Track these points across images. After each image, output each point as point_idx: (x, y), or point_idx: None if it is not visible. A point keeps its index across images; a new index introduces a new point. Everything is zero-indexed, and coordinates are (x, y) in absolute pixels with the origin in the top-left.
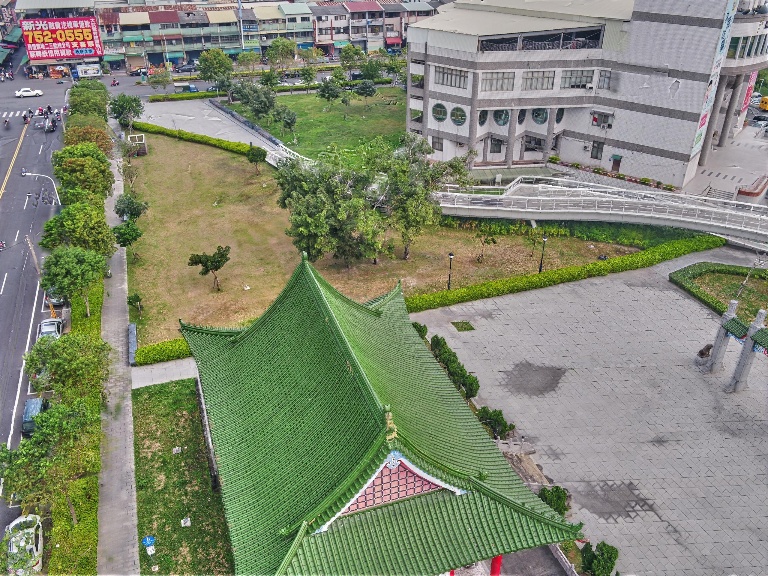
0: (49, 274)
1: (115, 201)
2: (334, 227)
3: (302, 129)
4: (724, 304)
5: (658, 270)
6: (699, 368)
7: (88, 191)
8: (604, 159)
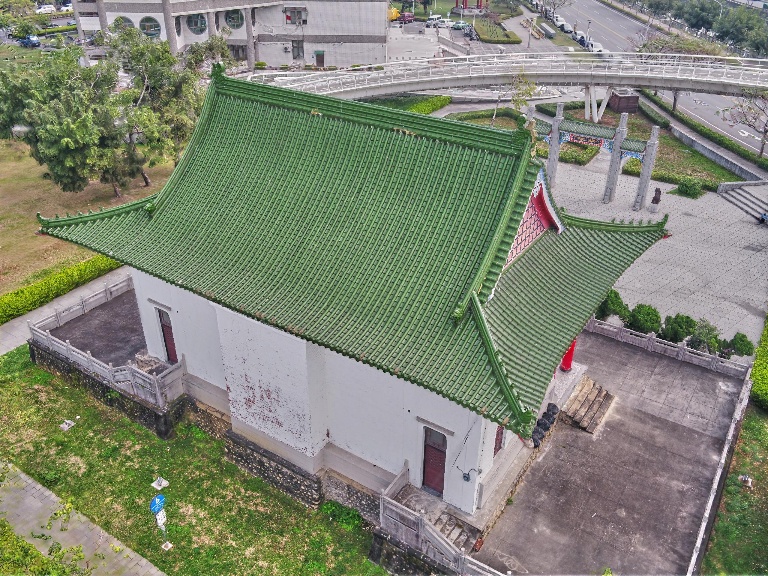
0: None
1: None
2: (101, 135)
3: None
4: None
5: None
6: None
7: None
8: (307, 57)
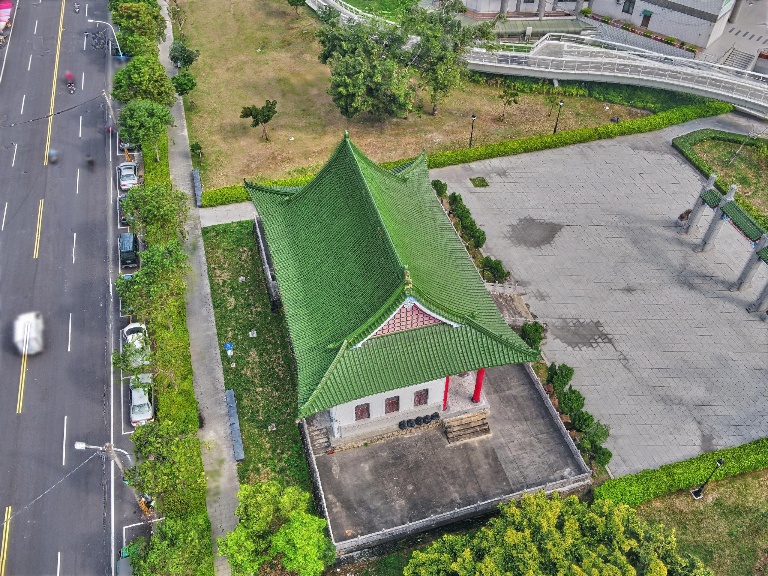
0: (125, 126)
1: (169, 49)
2: (370, 87)
3: None
4: (715, 171)
5: (664, 134)
6: (677, 229)
7: (145, 38)
8: (635, 14)
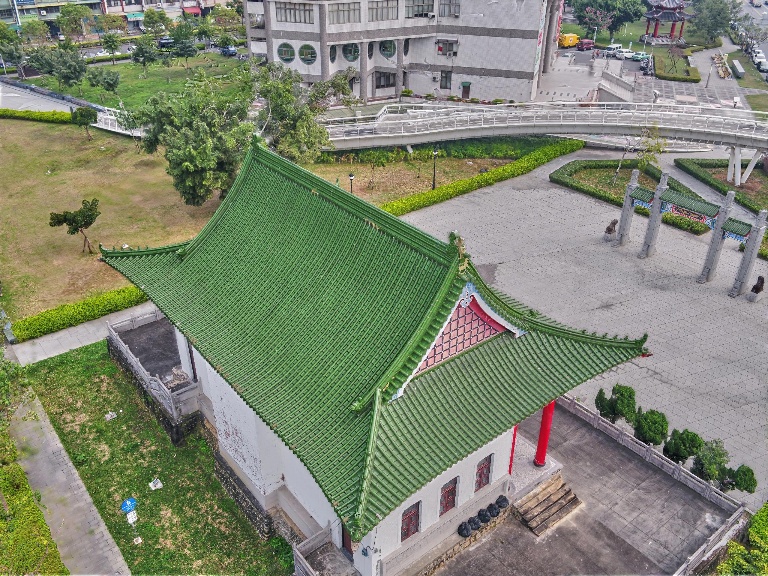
0: None
1: None
2: (220, 161)
3: (123, 95)
4: (606, 191)
5: (537, 174)
6: (609, 244)
7: None
8: (454, 88)
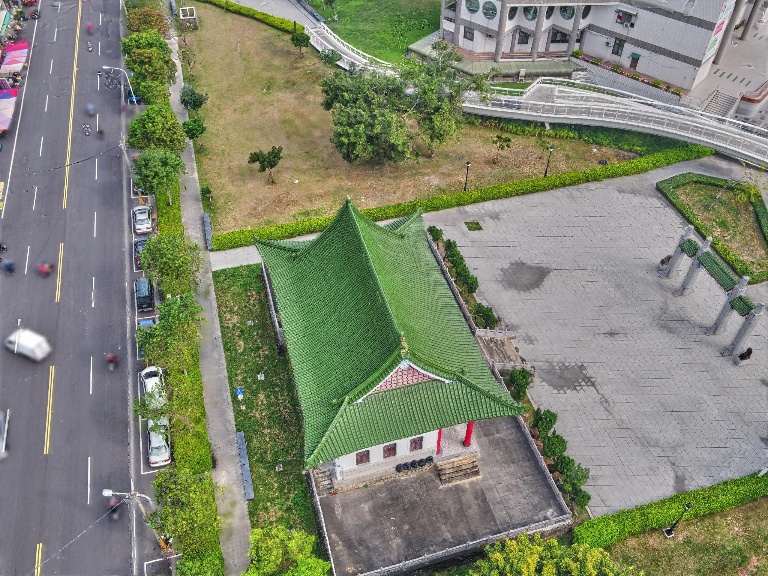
0: (141, 175)
1: (180, 93)
2: (370, 135)
3: (342, 1)
4: (696, 215)
5: (649, 177)
6: (659, 273)
7: (157, 84)
8: (624, 56)
